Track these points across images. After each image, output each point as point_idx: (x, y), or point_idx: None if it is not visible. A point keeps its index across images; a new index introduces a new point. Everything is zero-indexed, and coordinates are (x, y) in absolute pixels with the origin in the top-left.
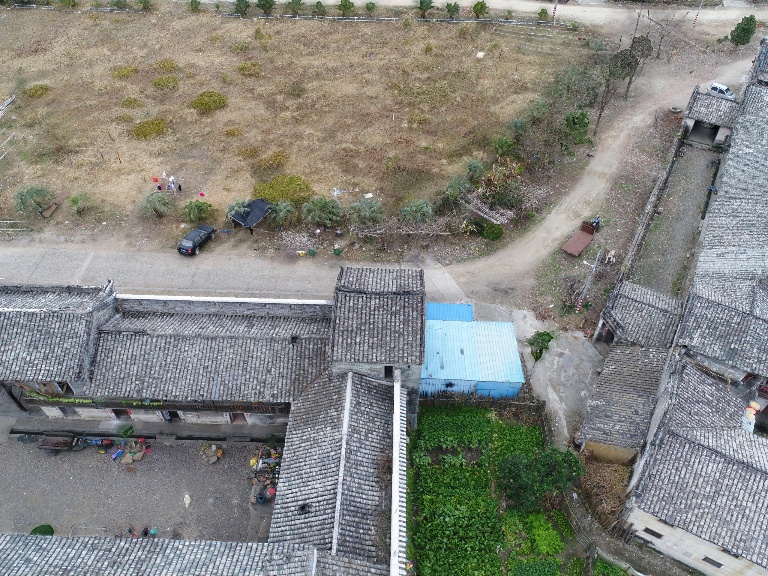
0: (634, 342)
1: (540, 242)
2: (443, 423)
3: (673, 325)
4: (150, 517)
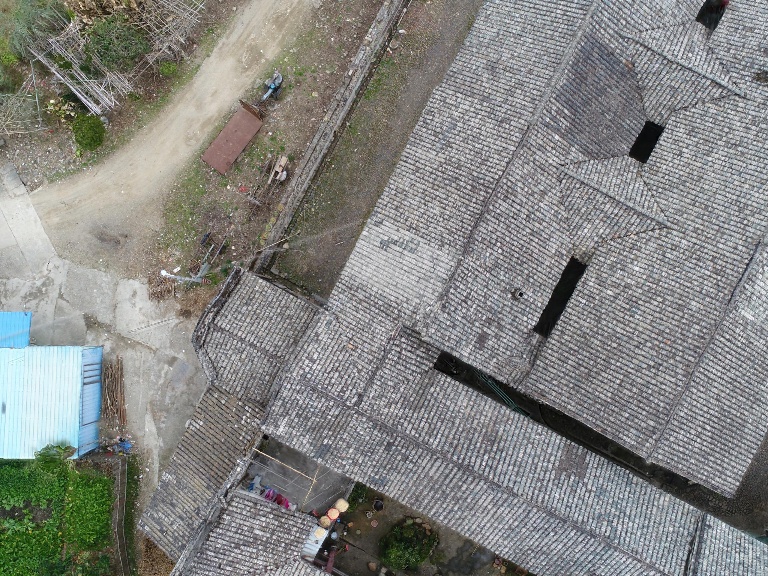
0: (230, 392)
1: (181, 130)
2: (8, 477)
3: None
4: None
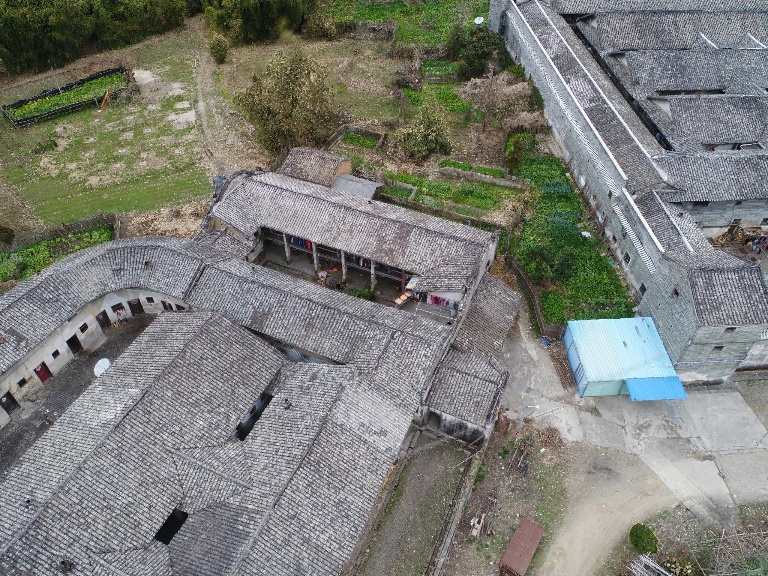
0: None
1: (570, 562)
2: None
3: (447, 361)
4: (765, 268)
